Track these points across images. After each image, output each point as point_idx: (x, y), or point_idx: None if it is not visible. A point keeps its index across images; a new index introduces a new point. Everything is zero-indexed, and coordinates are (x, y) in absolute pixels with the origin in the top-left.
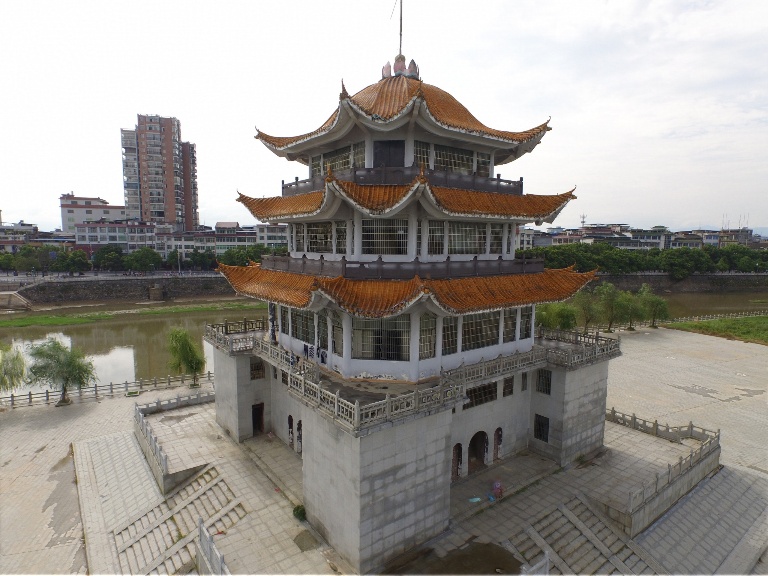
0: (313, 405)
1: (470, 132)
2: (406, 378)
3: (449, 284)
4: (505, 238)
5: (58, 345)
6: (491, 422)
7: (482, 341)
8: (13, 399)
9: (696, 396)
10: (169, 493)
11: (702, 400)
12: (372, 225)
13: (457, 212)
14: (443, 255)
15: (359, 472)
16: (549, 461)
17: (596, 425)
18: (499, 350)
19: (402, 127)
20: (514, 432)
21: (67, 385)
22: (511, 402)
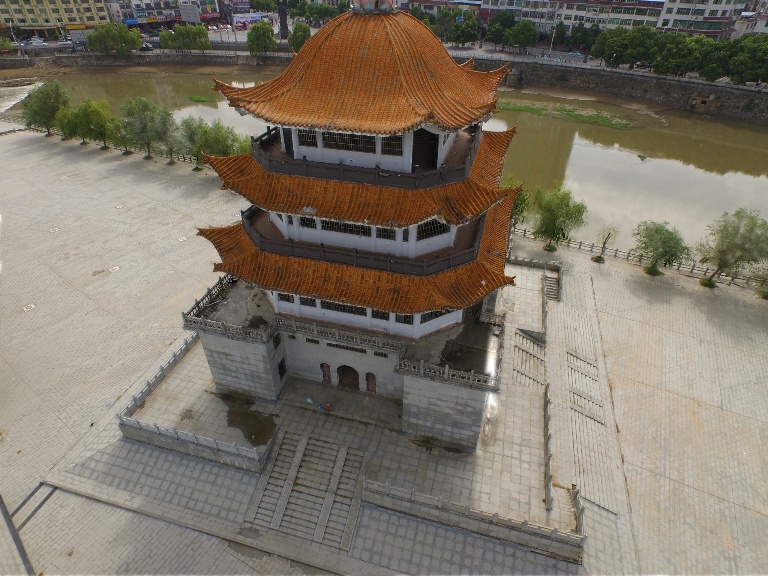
0: None
1: (310, 129)
2: None
3: (287, 260)
4: None
5: None
6: (361, 365)
7: (345, 308)
8: None
9: None
10: None
11: None
12: None
13: (275, 210)
14: (316, 229)
15: None
16: (400, 420)
17: (462, 428)
18: (367, 321)
19: None
20: (391, 383)
21: None
22: (386, 362)
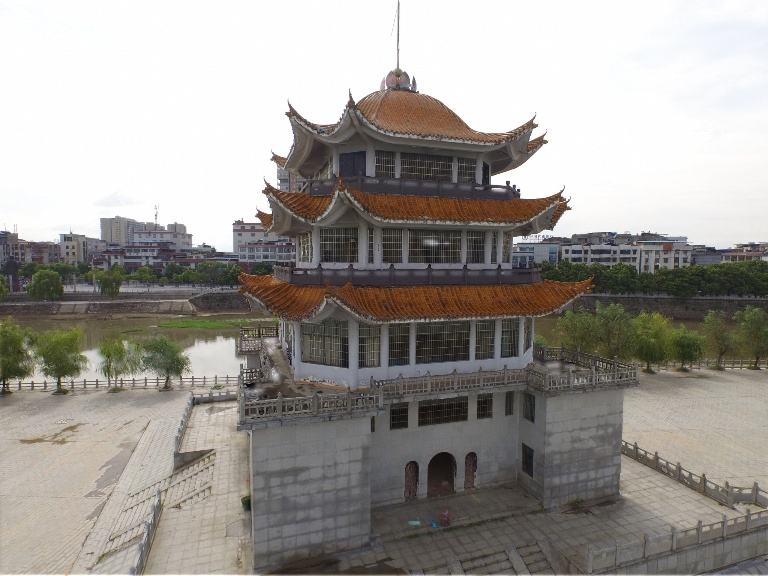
0: (238, 399)
1: (423, 137)
2: (346, 385)
3: (390, 292)
4: (488, 247)
5: (165, 341)
6: (460, 444)
7: (445, 355)
8: (134, 382)
9: None
10: (177, 469)
11: None
12: (328, 234)
13: (392, 219)
14: (402, 264)
15: (252, 466)
16: (531, 499)
17: (604, 467)
18: (470, 367)
19: (357, 138)
20: (495, 460)
21: (166, 374)
22: (489, 426)
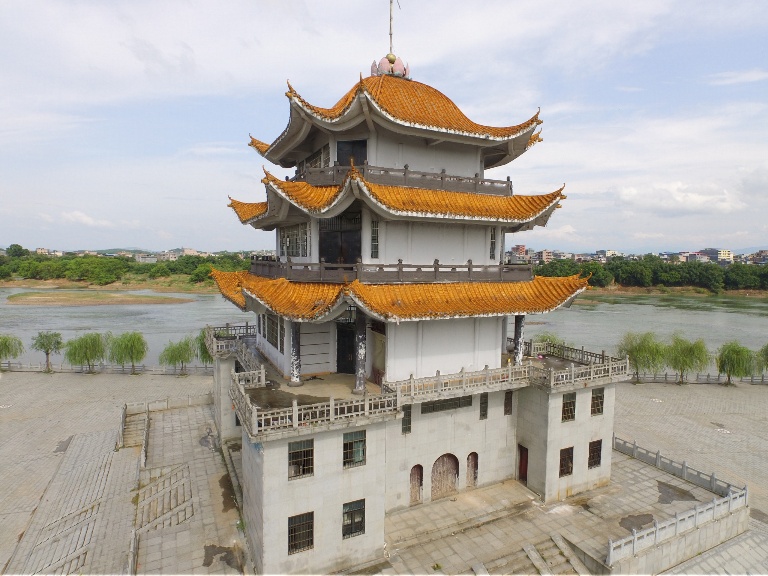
0: None
1: None
2: None
3: None
4: None
5: None
6: None
7: None
8: None
9: None
10: None
11: None
12: None
13: None
14: None
15: None
16: None
17: None
18: None
19: None
20: None
21: None
22: None
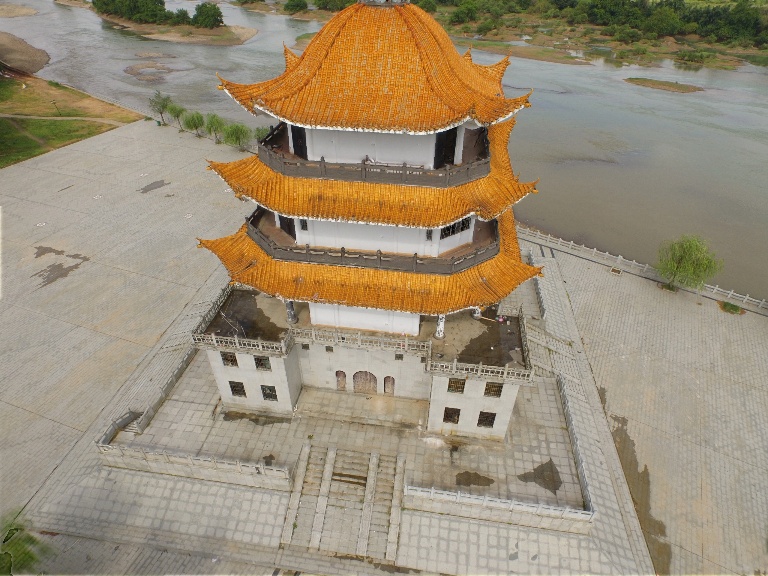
0: None
1: None
2: None
3: None
4: None
5: None
6: None
7: None
8: None
9: (80, 271)
10: None
11: (92, 267)
12: None
13: None
14: None
15: None
16: None
17: None
18: None
19: None
20: None
21: None
22: None
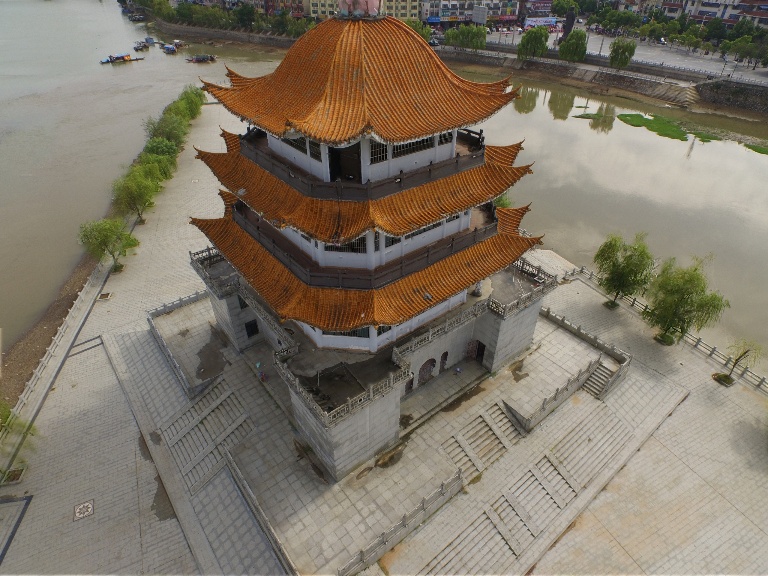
0: None
1: None
2: None
3: None
4: None
5: None
6: None
7: None
8: None
9: None
10: None
11: None
12: None
13: None
14: None
15: None
16: None
17: (325, 454)
18: None
19: None
20: None
21: None
22: None
